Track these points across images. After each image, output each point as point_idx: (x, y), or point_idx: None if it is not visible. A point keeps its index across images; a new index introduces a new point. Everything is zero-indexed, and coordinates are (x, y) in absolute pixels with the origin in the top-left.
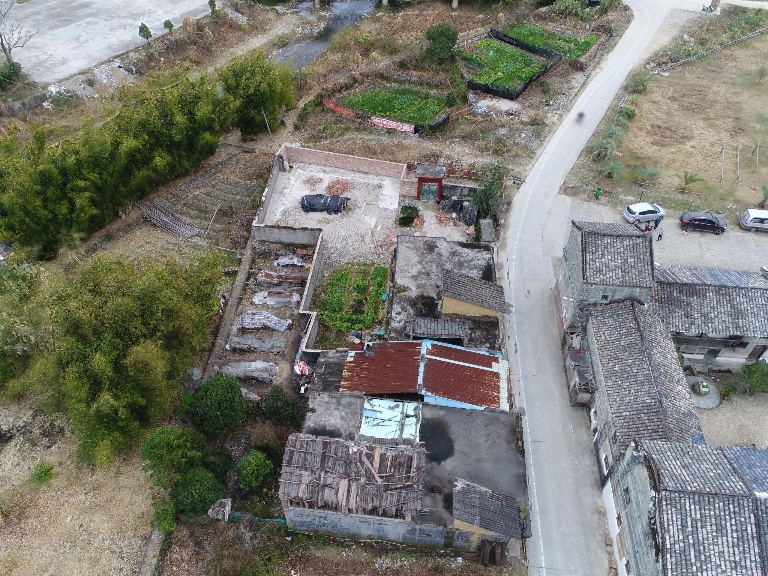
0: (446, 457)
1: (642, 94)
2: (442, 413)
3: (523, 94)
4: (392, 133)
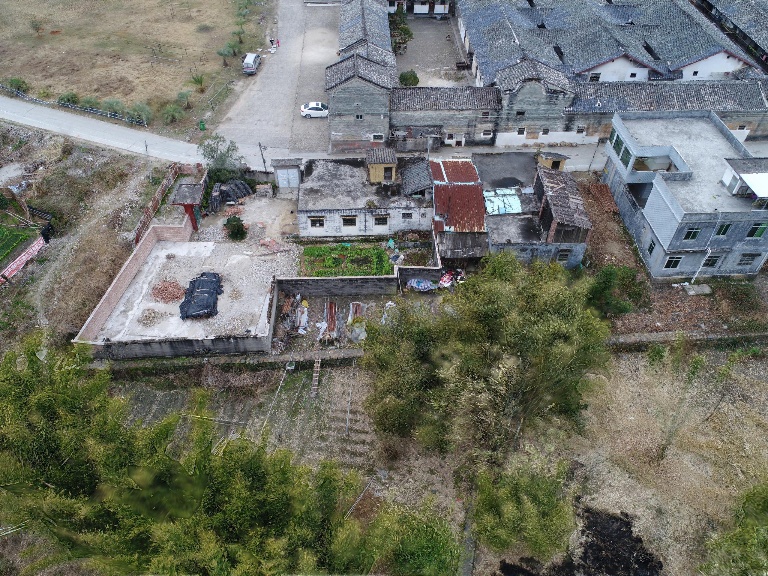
0: (517, 180)
1: (29, 90)
2: (485, 182)
3: None
4: (44, 259)
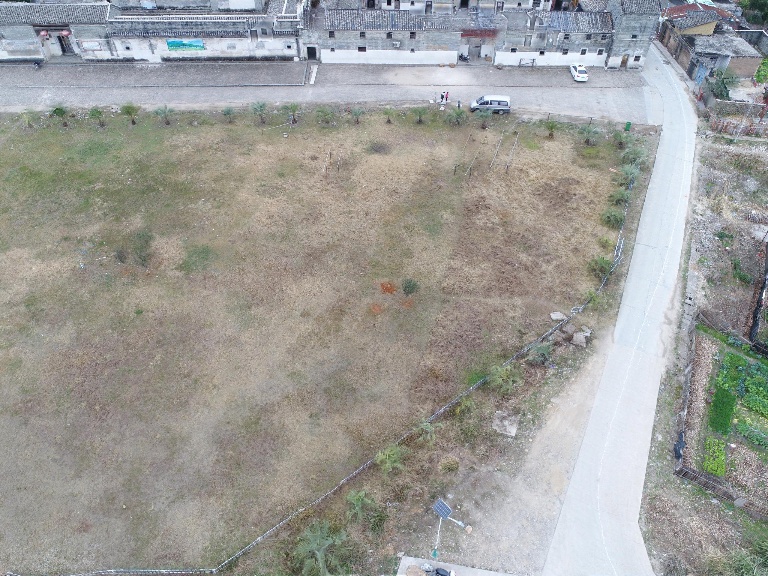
0: None
1: None
2: None
3: (764, 258)
4: None
